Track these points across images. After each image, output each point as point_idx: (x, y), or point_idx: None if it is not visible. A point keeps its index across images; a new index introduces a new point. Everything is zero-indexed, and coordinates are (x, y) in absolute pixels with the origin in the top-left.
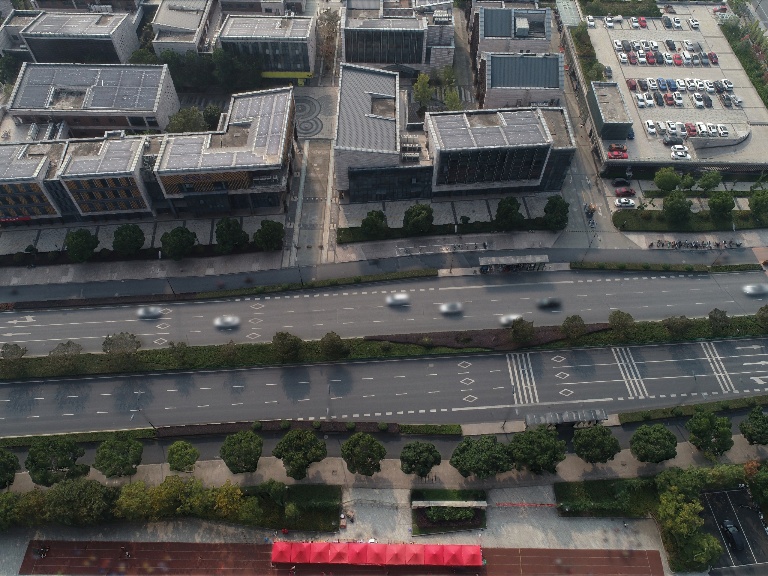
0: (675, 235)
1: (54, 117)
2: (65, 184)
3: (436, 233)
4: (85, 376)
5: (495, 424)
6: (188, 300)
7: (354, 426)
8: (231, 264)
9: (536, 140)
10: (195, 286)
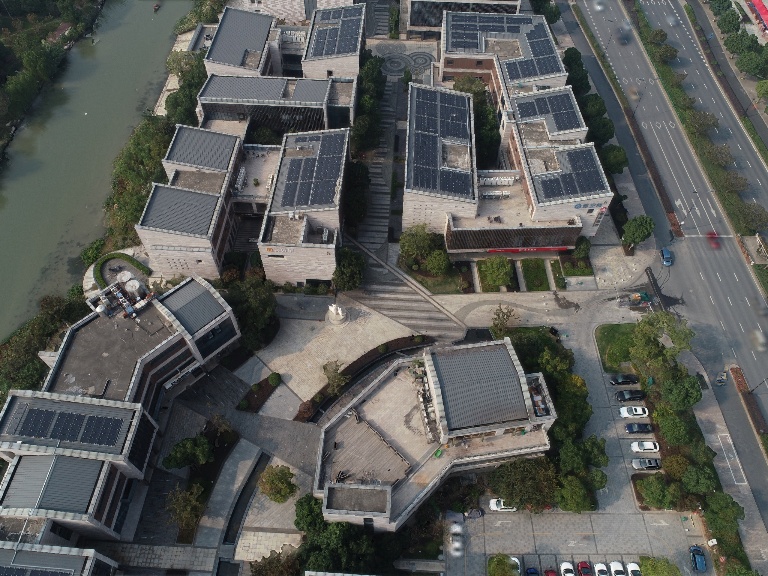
0: None
1: None
2: None
3: None
4: None
5: None
6: None
7: None
8: None
9: None
10: (616, 112)
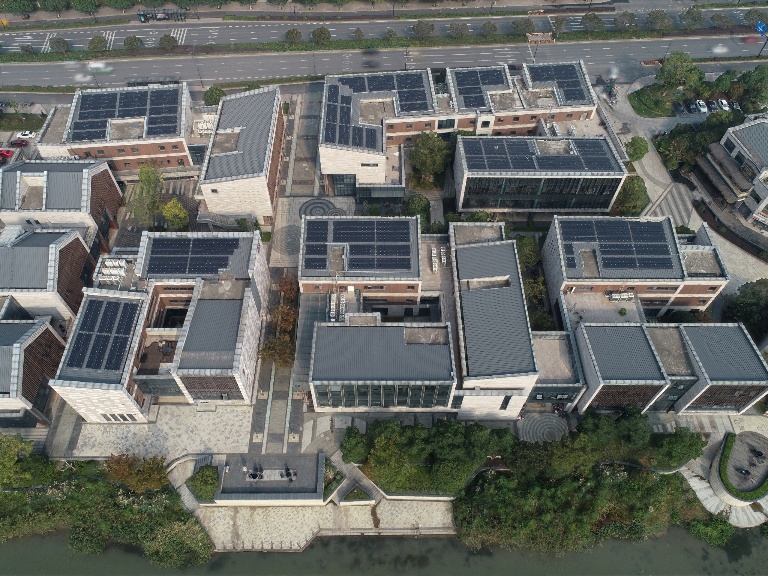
0: (4, 112)
1: None
2: None
3: None
4: None
5: (203, 21)
6: None
7: (283, 16)
8: None
9: (90, 98)
10: None
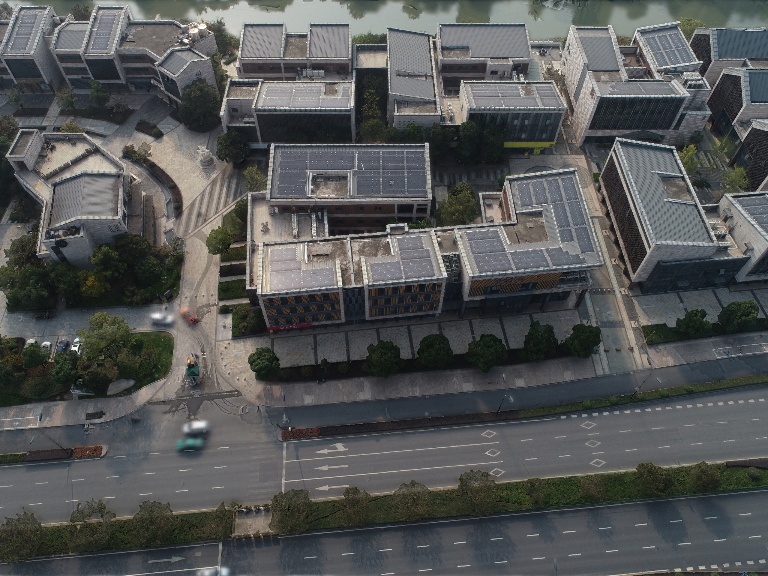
0: None
1: (316, 206)
2: (368, 292)
3: (752, 330)
4: (430, 520)
5: None
6: (510, 419)
7: None
8: (540, 373)
9: None
10: None
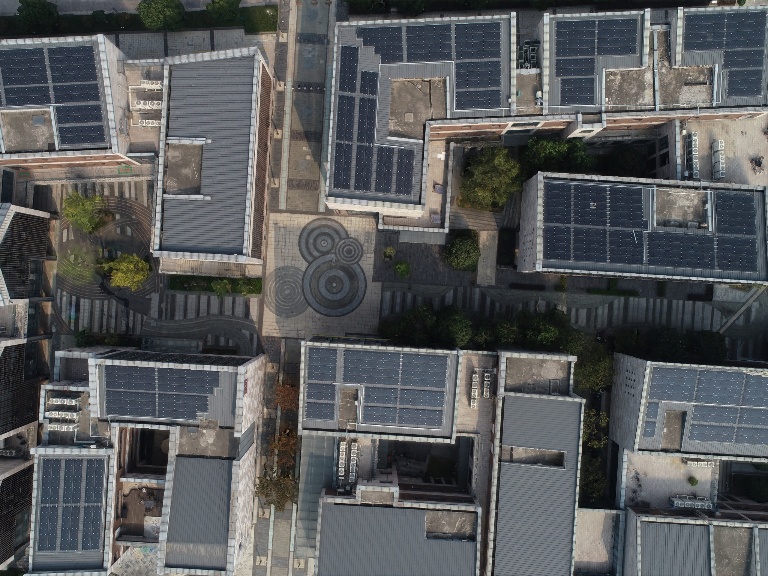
0: None
1: None
2: None
3: None
4: None
5: None
6: None
7: None
8: None
9: None
10: None
